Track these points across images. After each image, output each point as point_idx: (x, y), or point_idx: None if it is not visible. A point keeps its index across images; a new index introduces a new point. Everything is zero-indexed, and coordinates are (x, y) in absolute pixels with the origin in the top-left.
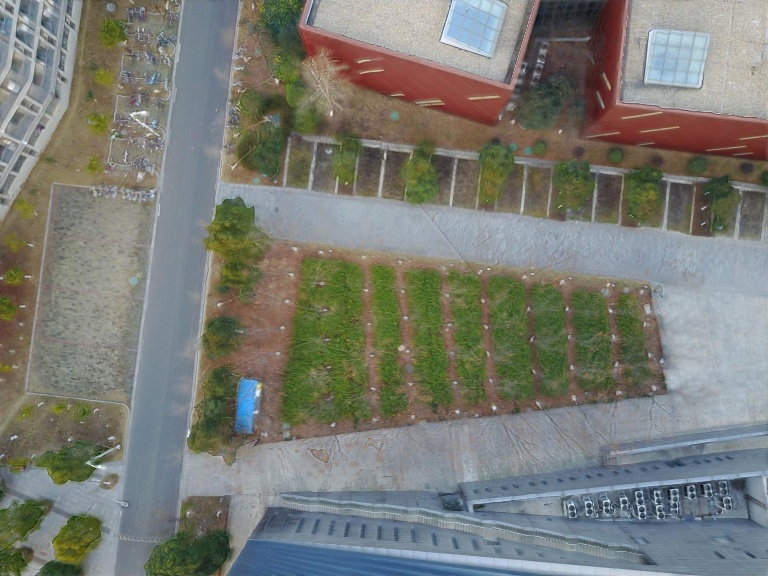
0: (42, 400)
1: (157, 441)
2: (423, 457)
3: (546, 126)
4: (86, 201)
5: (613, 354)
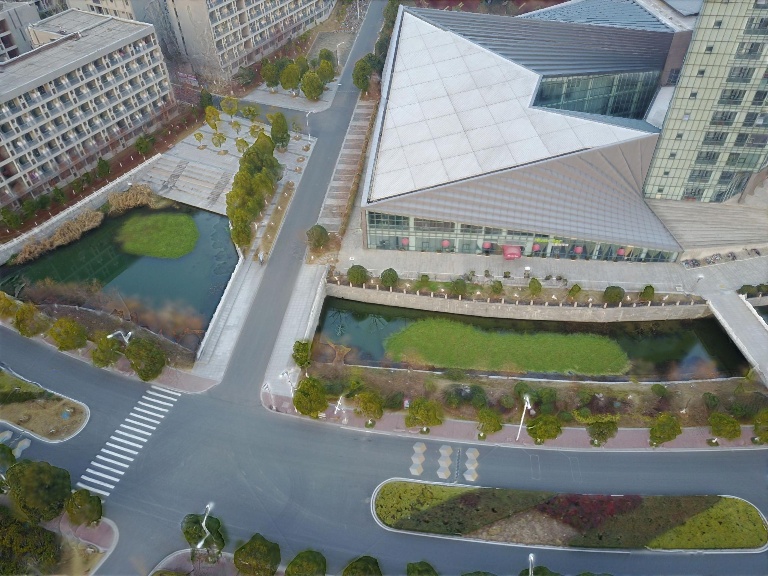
0: None
1: None
2: None
3: (500, 8)
4: (331, 34)
5: None
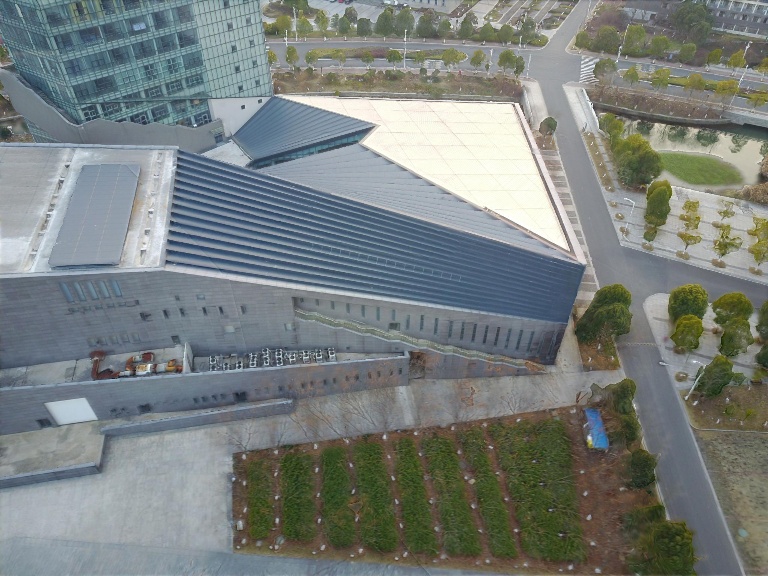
0: (767, 427)
1: (657, 404)
2: (440, 402)
3: None
4: None
5: (279, 482)
